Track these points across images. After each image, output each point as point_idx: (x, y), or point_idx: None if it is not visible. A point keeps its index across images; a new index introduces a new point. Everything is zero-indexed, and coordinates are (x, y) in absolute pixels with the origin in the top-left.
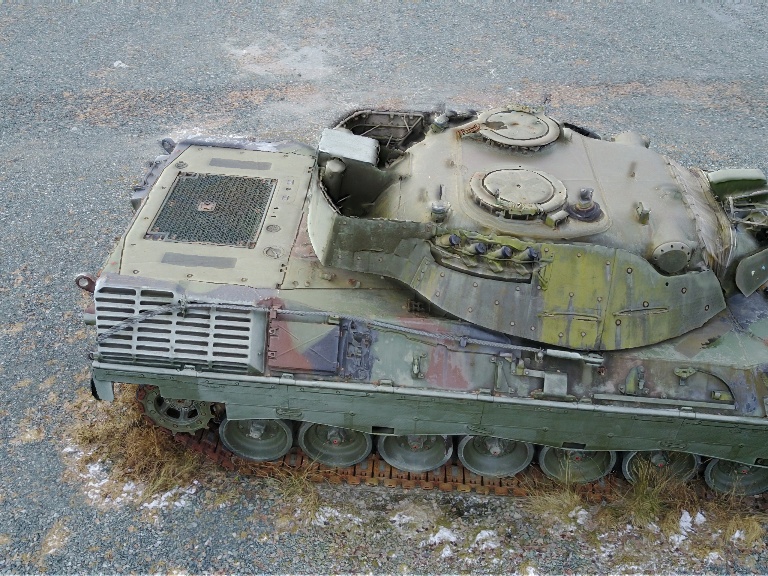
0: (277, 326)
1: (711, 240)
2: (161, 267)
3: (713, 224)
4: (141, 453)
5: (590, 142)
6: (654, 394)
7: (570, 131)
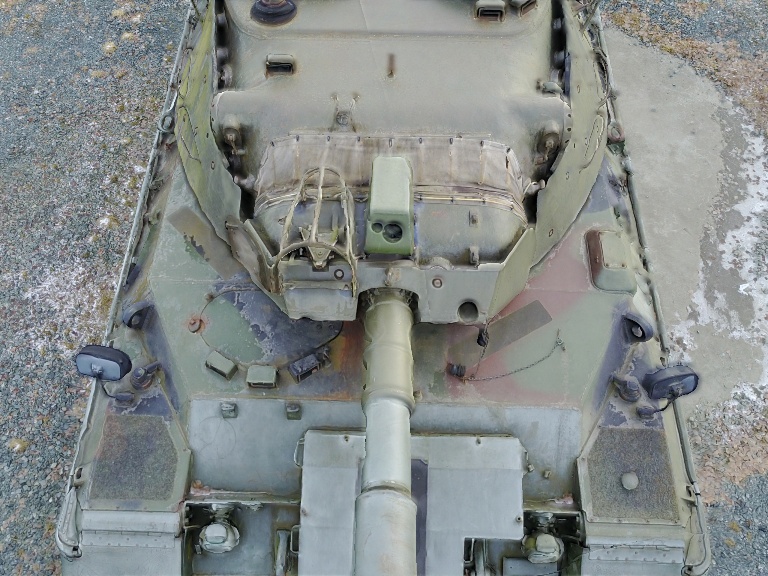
0: None
1: (275, 173)
2: None
3: (302, 172)
4: None
5: (498, 47)
6: (151, 207)
7: (488, 4)
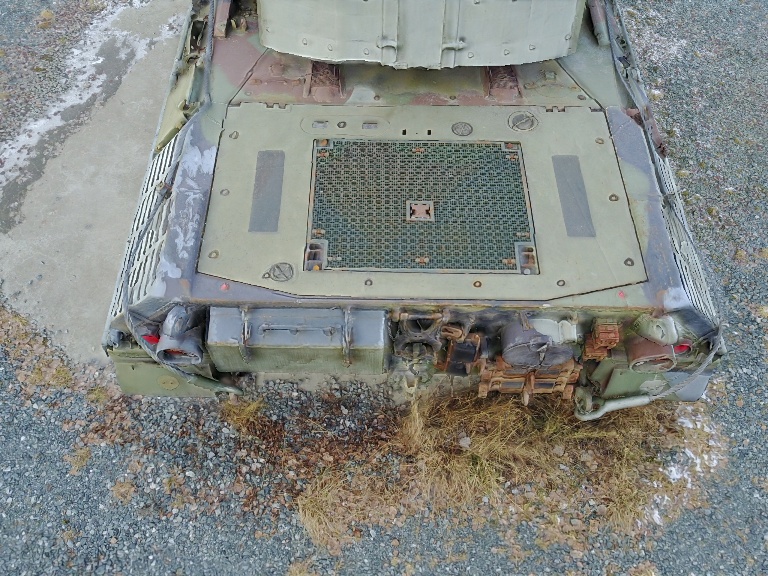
0: (647, 123)
1: None
2: (609, 235)
3: None
4: (654, 407)
5: None
6: None
7: None
